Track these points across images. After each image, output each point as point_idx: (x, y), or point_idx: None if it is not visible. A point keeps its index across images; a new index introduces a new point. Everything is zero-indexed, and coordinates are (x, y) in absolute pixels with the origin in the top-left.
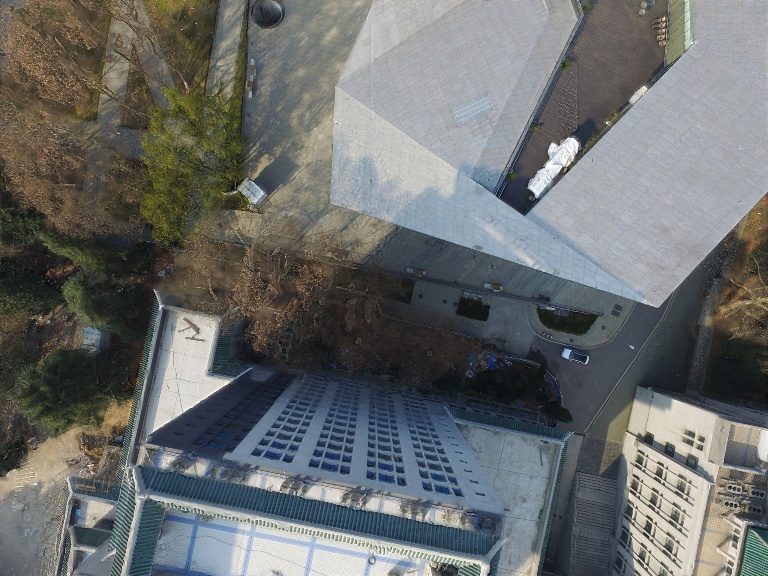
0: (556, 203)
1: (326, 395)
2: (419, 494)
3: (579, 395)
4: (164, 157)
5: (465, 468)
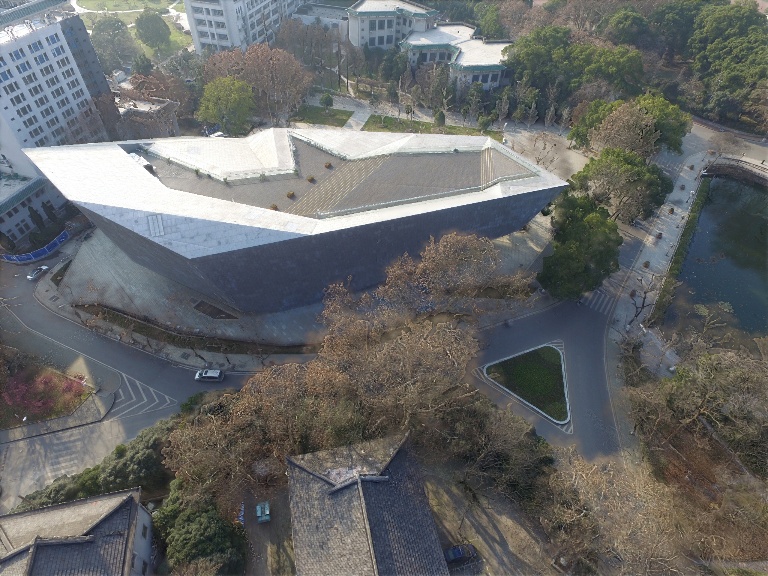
0: (115, 149)
1: (91, 139)
2: (1, 49)
3: (8, 275)
4: (217, 80)
5: (2, 99)
